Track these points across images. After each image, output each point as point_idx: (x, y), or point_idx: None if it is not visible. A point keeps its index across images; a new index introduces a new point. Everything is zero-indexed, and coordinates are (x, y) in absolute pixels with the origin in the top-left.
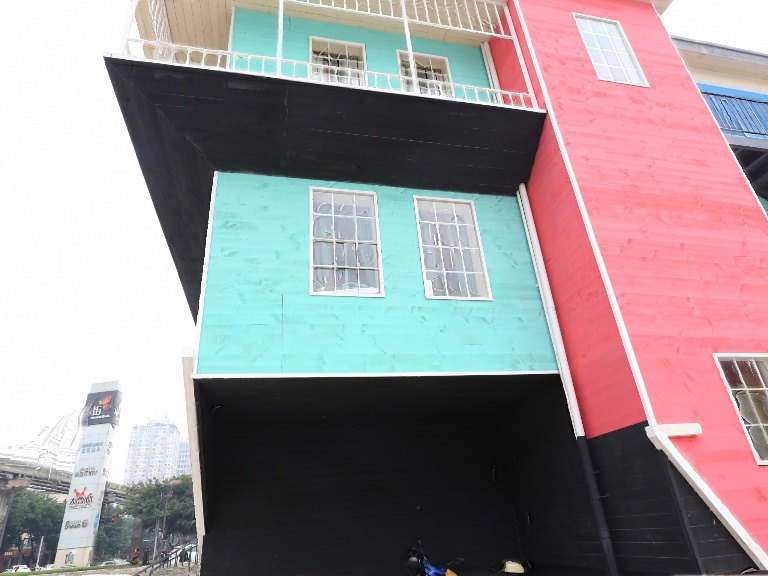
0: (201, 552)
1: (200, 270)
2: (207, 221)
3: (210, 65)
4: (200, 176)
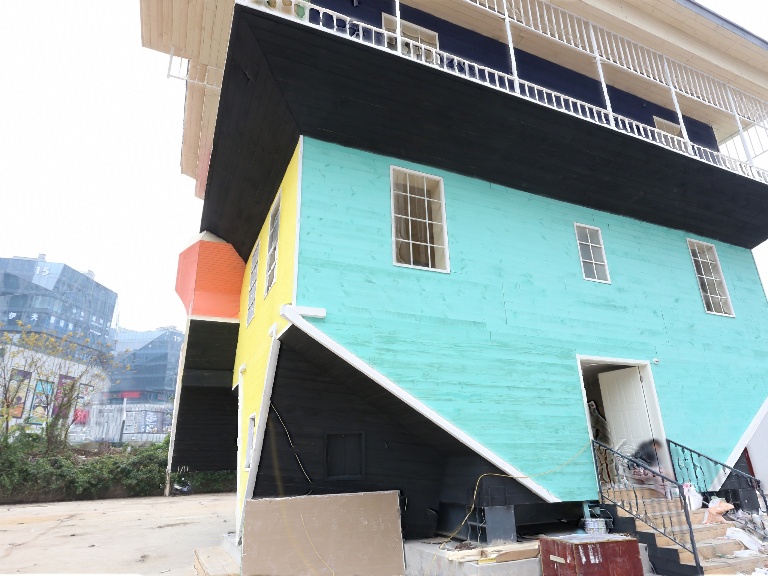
0: (738, 457)
1: (670, 189)
2: (722, 228)
3: (700, 101)
4: (752, 237)
